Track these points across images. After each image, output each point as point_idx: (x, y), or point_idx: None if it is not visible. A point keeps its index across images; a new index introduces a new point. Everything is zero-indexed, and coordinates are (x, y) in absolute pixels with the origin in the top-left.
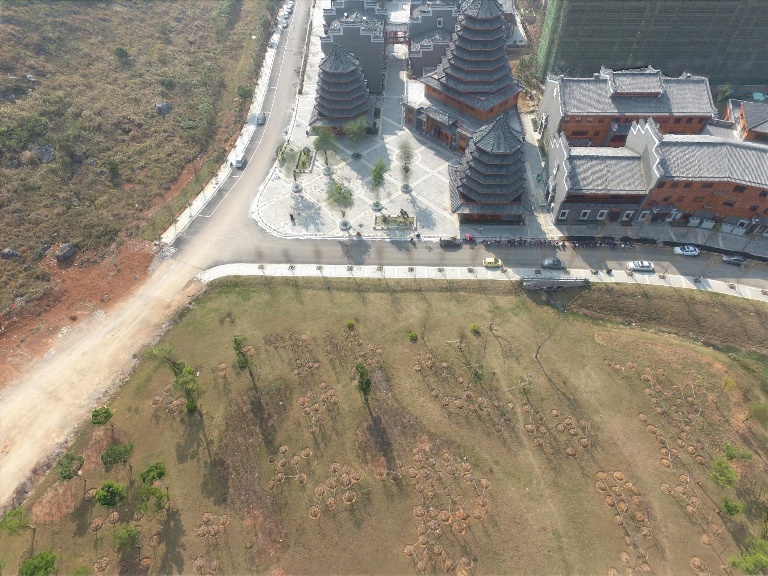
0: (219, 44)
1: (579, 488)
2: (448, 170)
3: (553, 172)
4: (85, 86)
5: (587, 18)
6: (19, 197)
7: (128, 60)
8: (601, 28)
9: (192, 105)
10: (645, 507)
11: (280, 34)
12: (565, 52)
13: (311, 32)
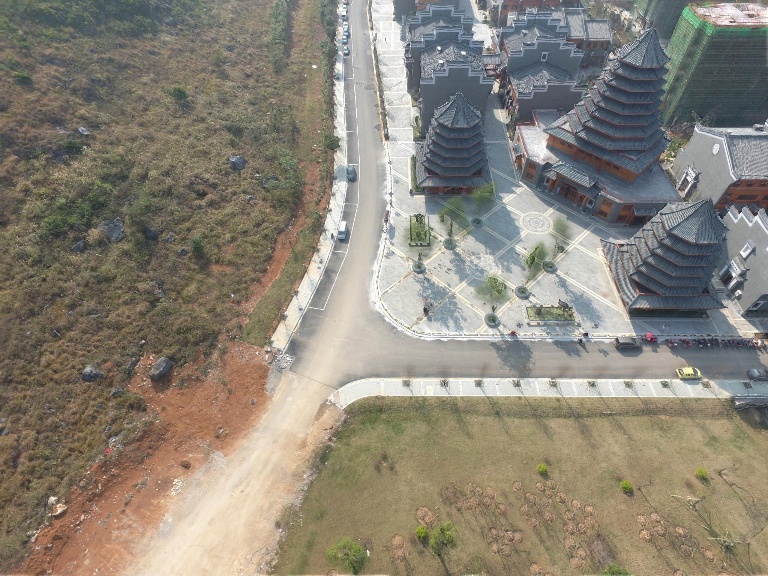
0: (278, 76)
1: None
2: (602, 246)
3: (741, 253)
4: (145, 138)
5: (728, 55)
6: (91, 292)
7: (186, 101)
8: (741, 66)
9: (268, 156)
10: None
11: (343, 63)
12: (694, 92)
13: (378, 60)
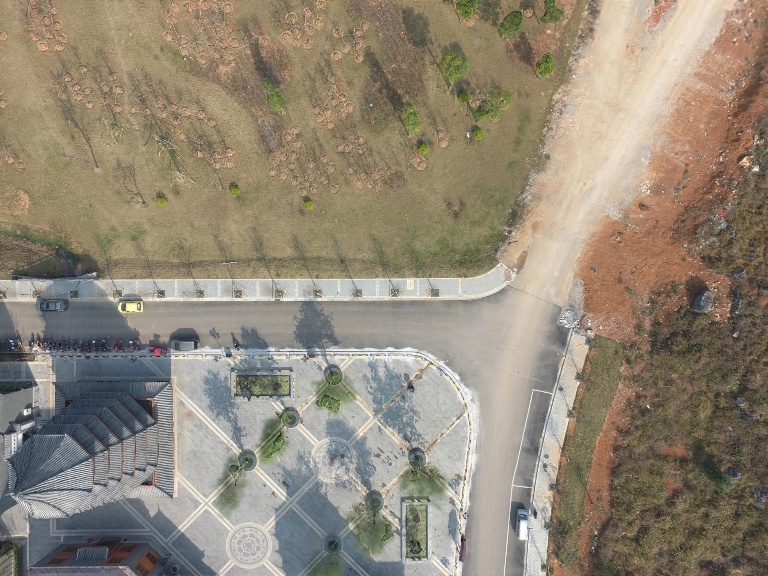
0: None
1: (83, 37)
2: None
3: None
4: None
5: None
6: None
7: None
8: None
9: None
10: (27, 20)
11: None
12: None
13: None
